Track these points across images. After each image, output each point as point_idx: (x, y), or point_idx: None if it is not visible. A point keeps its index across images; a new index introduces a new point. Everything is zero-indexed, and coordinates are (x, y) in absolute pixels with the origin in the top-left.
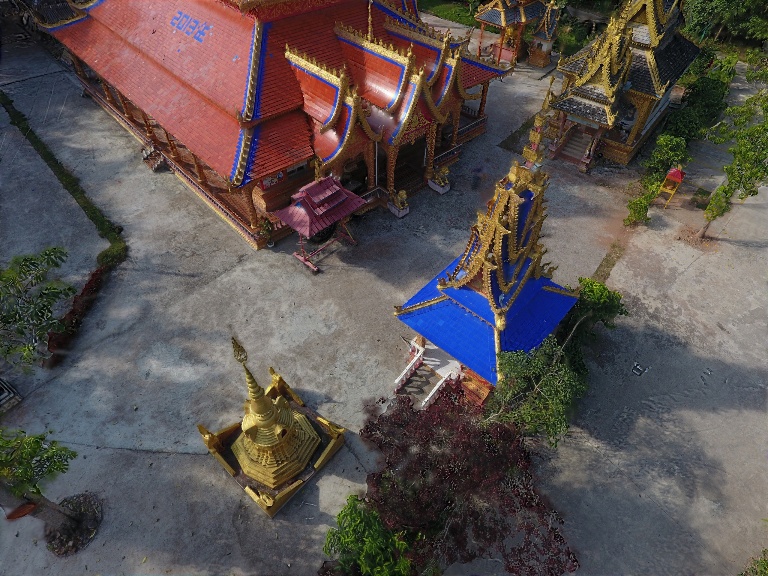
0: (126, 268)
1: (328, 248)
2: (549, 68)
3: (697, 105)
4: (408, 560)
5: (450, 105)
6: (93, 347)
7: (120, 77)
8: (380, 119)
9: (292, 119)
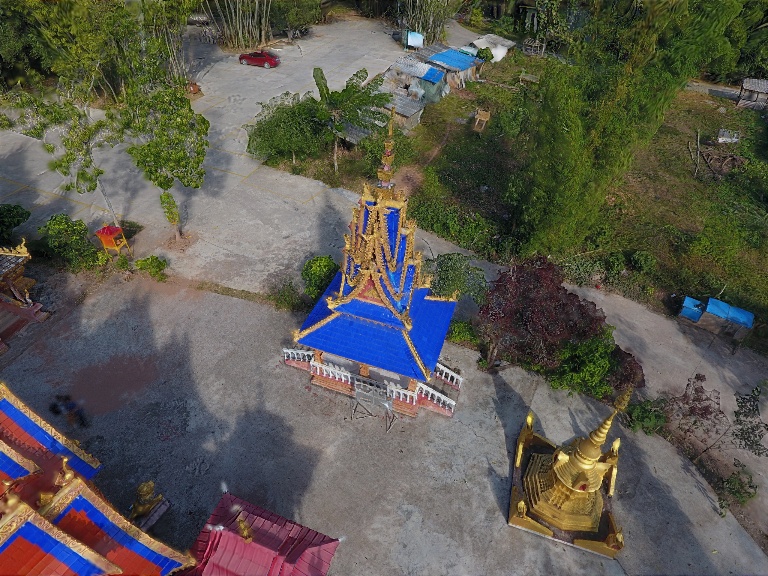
0: None
1: None
2: None
3: None
4: None
5: None
6: None
7: None
8: None
9: None
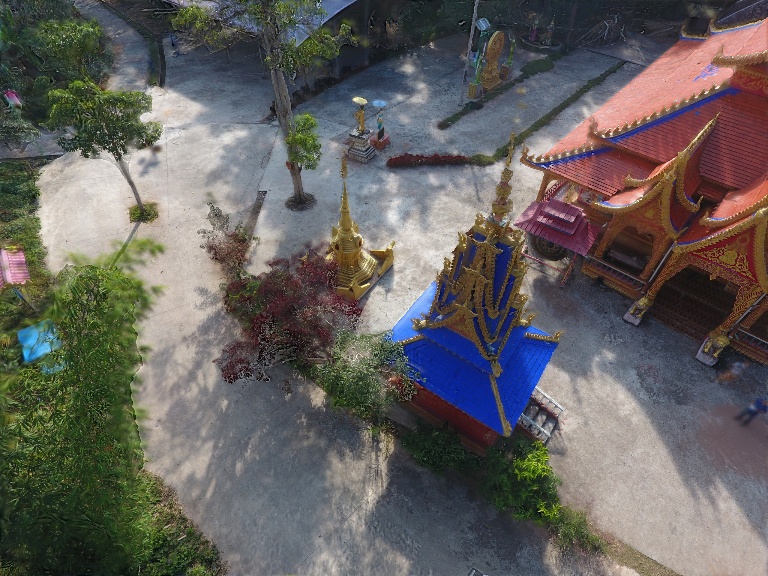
0: (473, 169)
1: (547, 268)
2: None
3: None
4: None
5: None
6: (405, 175)
7: (640, 80)
8: (703, 226)
9: (641, 166)
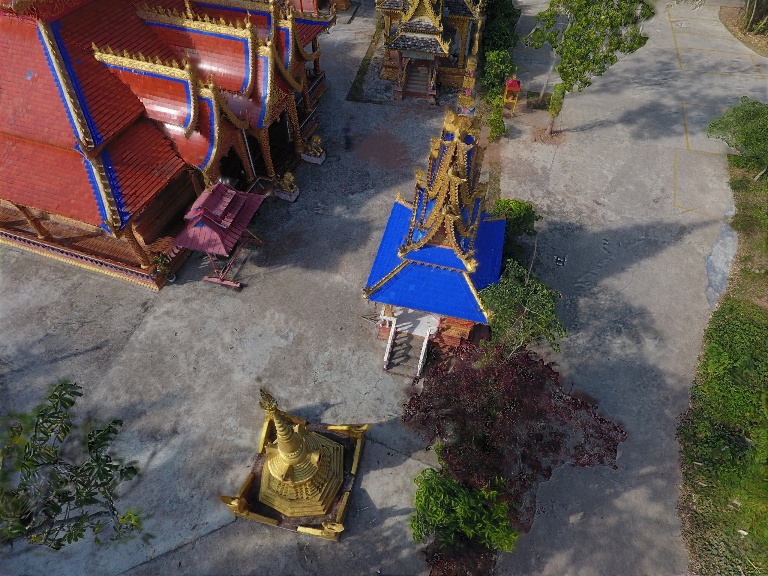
0: (2, 374)
1: (237, 259)
2: (352, 9)
3: (499, 17)
4: (503, 504)
5: (295, 70)
6: None
7: None
8: (238, 104)
9: (139, 131)
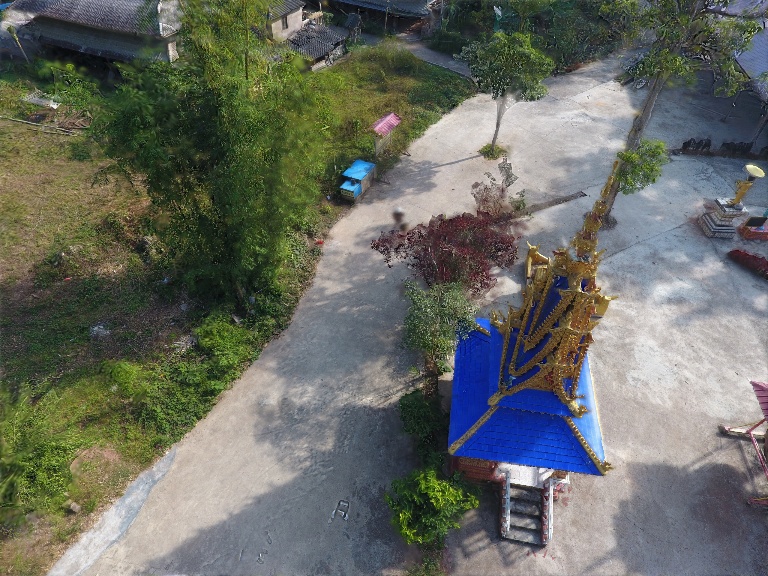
0: None
1: (763, 475)
2: None
3: None
4: None
5: None
6: (735, 275)
7: None
8: None
9: None
